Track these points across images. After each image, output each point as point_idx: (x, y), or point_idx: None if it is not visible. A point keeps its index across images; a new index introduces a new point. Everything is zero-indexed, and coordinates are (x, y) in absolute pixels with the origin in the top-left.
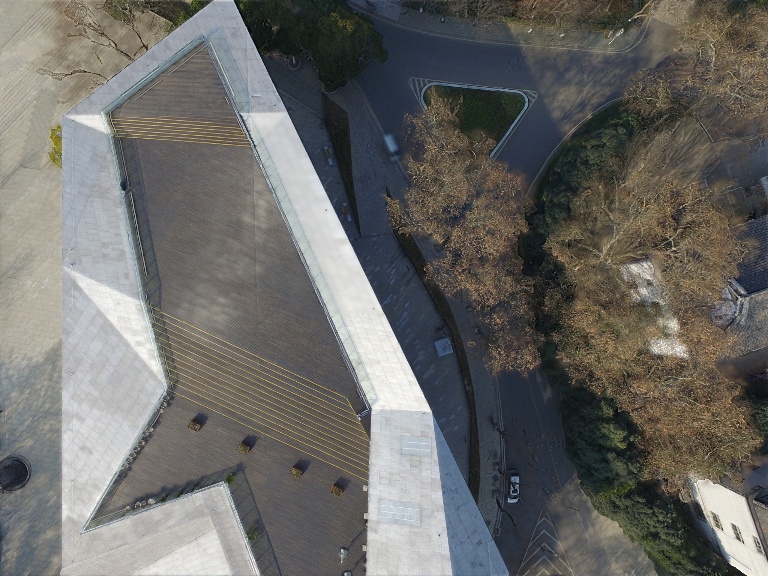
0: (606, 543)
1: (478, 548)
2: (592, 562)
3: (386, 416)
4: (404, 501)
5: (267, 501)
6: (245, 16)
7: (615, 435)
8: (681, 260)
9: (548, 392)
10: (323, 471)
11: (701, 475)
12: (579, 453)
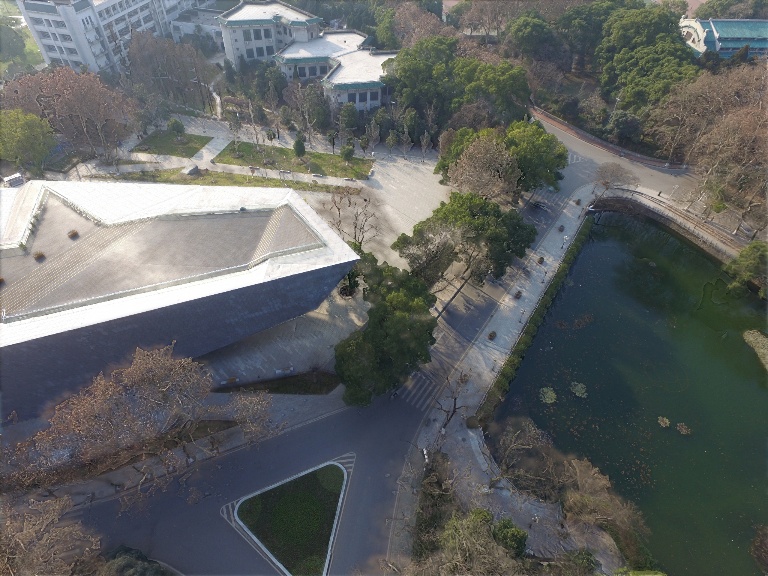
0: None
1: None
2: None
3: None
4: None
5: None
6: (373, 291)
7: None
8: None
9: None
10: None
11: None
12: None
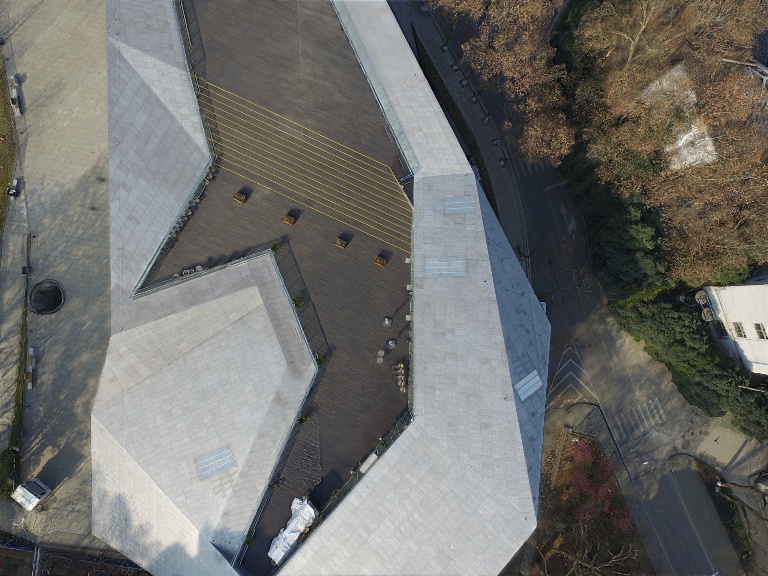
0: (630, 371)
1: (522, 298)
2: (617, 389)
3: (428, 182)
4: (449, 256)
5: (312, 272)
6: None
7: (644, 233)
8: (716, 1)
9: (572, 223)
10: (366, 244)
11: (729, 256)
12: (607, 262)
